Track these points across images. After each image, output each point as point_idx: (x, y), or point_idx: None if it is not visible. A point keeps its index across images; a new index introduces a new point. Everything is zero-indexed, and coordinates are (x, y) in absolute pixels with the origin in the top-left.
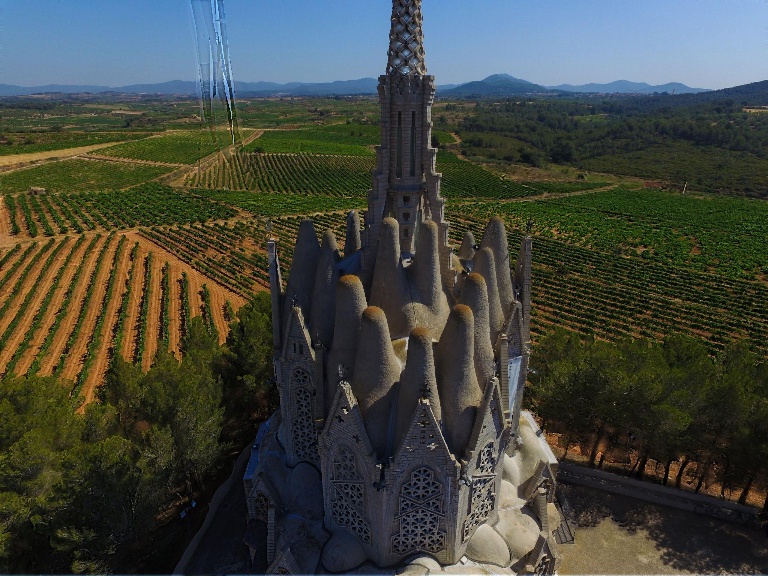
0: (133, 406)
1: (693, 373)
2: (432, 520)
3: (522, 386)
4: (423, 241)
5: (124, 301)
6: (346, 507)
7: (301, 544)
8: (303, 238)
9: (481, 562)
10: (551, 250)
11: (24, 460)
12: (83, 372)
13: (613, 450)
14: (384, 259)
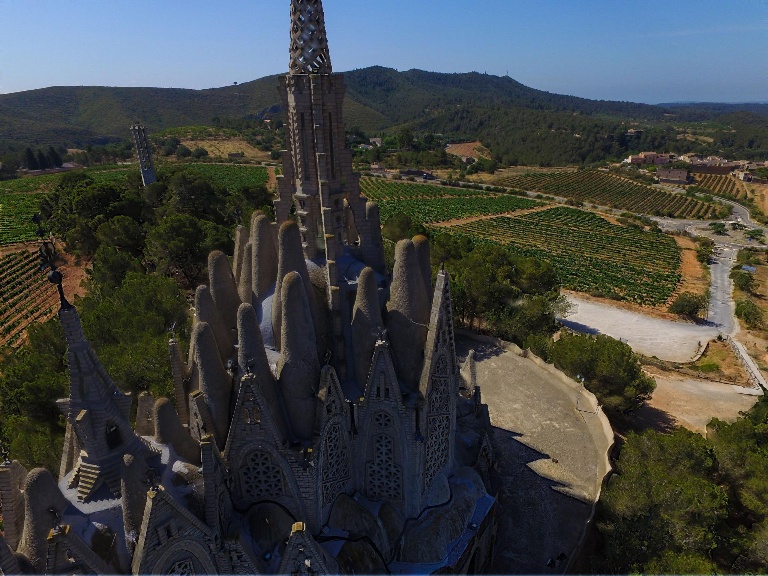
0: None
1: None
2: None
3: None
4: None
5: None
6: None
7: (469, 424)
8: None
9: None
10: None
11: None
12: None
13: None
14: None
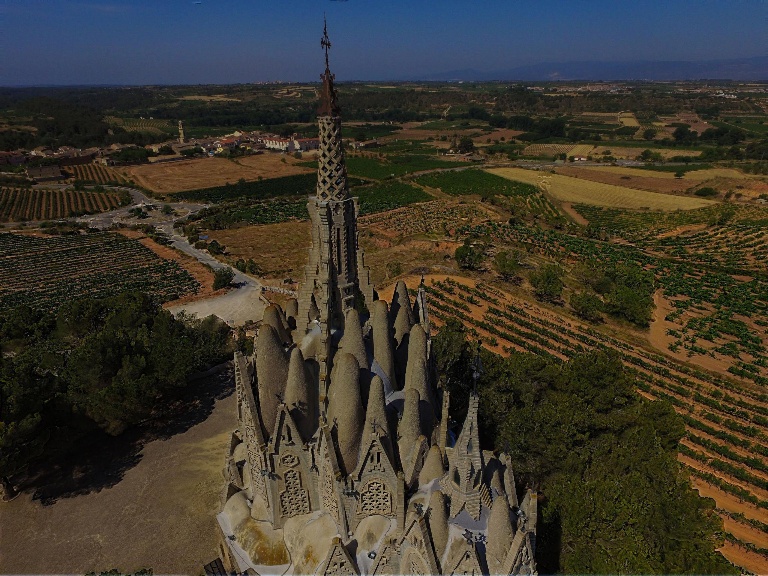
0: None
1: None
2: None
3: None
4: None
5: None
6: None
7: None
8: None
9: None
10: None
11: None
12: None
13: None
14: None
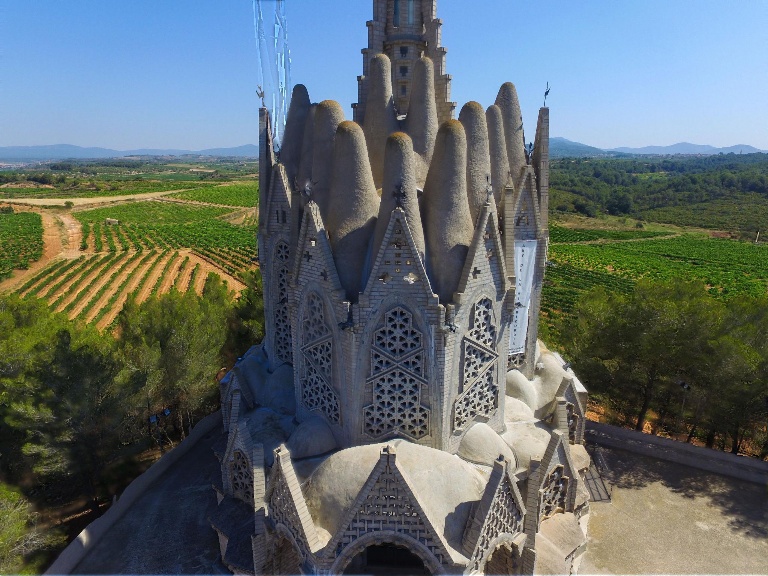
0: (131, 332)
1: (762, 310)
2: (412, 389)
3: (540, 285)
4: (416, 78)
5: None
6: (316, 381)
7: (264, 431)
8: (295, 103)
9: (477, 462)
10: (604, 281)
11: (7, 355)
12: None
13: (664, 415)
14: (373, 99)
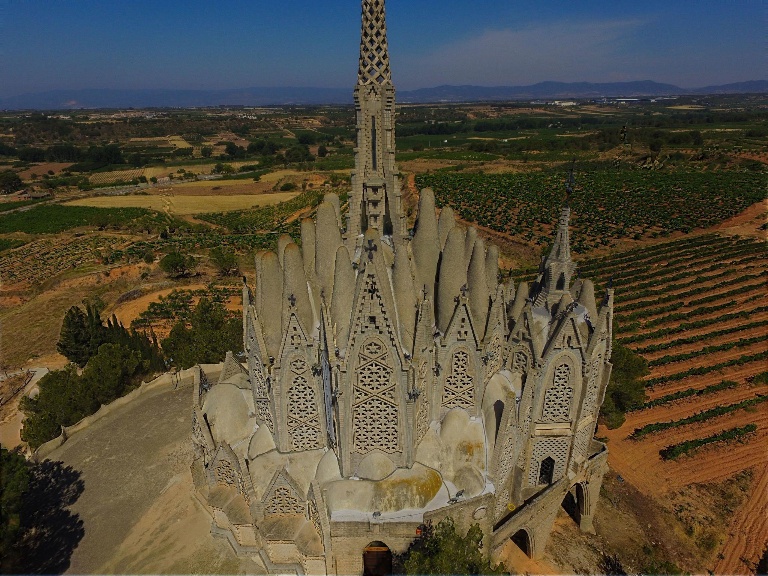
0: None
1: None
2: None
3: None
4: None
5: (701, 307)
6: None
7: None
8: None
9: None
10: None
11: None
12: None
13: None
14: None
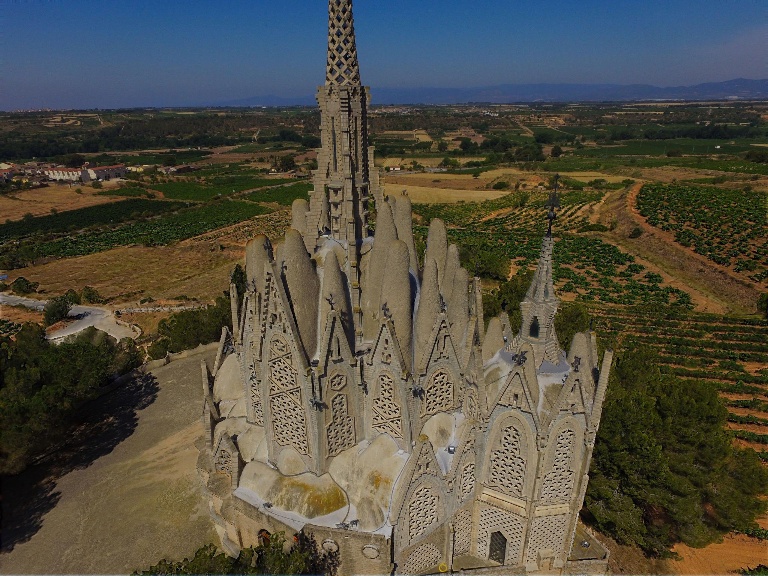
0: None
1: None
2: None
3: None
4: None
5: None
6: None
7: None
8: None
9: None
10: None
11: None
12: (761, 402)
13: None
14: None
